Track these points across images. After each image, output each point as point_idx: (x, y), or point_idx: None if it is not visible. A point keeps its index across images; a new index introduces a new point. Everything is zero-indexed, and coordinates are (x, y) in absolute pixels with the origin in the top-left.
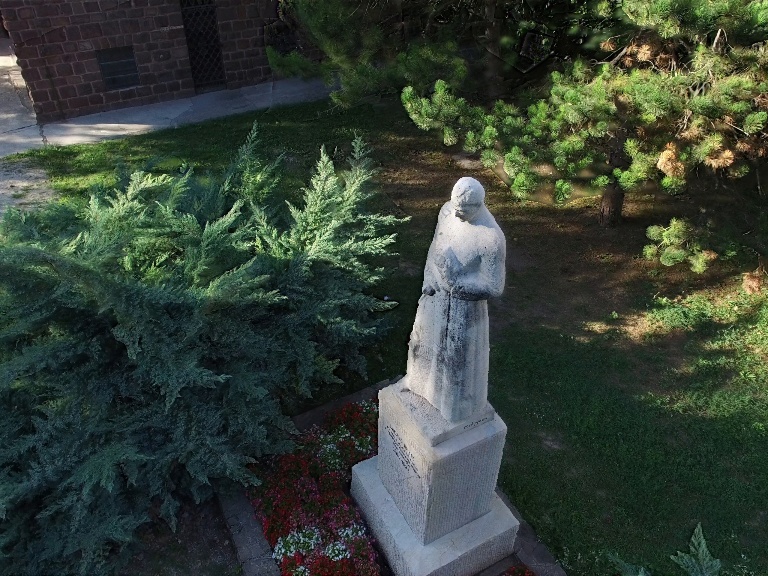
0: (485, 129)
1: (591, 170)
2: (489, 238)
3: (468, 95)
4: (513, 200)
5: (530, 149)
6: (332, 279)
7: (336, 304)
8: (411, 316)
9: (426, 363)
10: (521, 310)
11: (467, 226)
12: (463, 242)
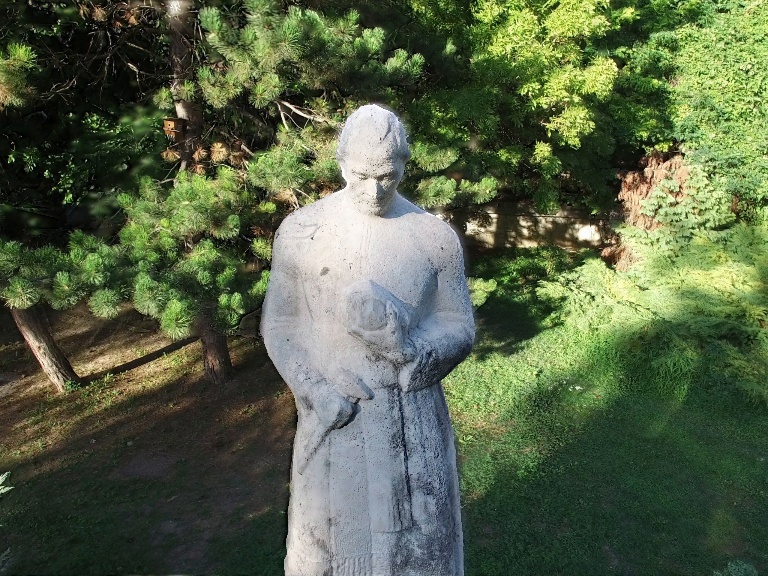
0: None
1: (237, 282)
2: (437, 228)
3: (21, 233)
4: (90, 405)
5: (155, 276)
6: None
7: None
8: None
9: None
10: (208, 516)
11: (383, 223)
12: (392, 257)
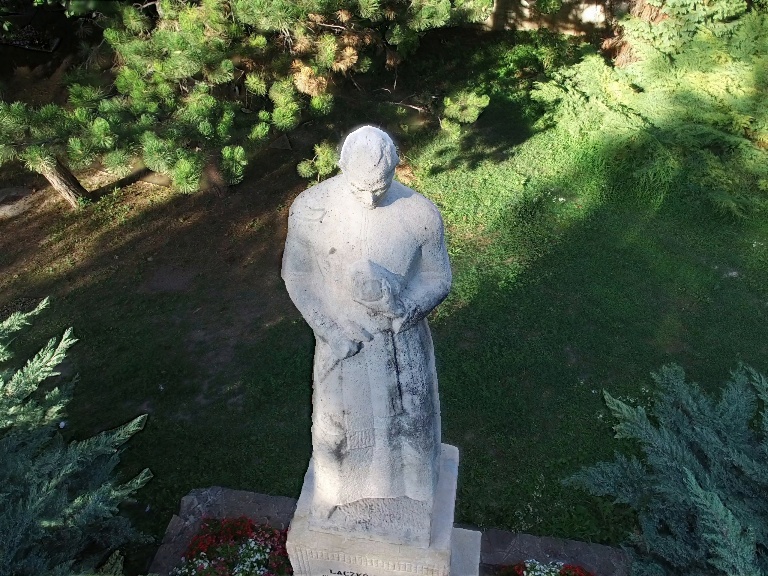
0: (93, 126)
1: (237, 125)
2: (423, 212)
3: (24, 94)
4: (106, 221)
5: (159, 130)
6: (4, 457)
7: (57, 485)
8: (118, 421)
9: (364, 454)
10: (231, 326)
11: (379, 213)
12: (387, 241)
